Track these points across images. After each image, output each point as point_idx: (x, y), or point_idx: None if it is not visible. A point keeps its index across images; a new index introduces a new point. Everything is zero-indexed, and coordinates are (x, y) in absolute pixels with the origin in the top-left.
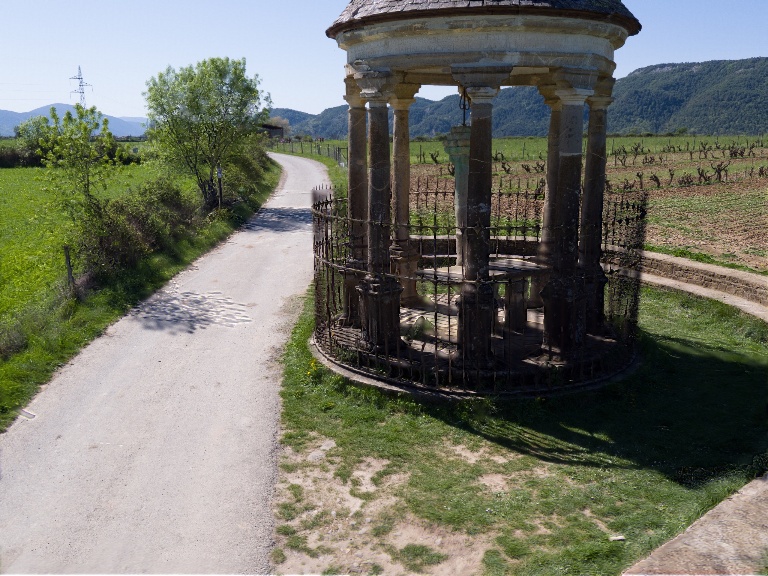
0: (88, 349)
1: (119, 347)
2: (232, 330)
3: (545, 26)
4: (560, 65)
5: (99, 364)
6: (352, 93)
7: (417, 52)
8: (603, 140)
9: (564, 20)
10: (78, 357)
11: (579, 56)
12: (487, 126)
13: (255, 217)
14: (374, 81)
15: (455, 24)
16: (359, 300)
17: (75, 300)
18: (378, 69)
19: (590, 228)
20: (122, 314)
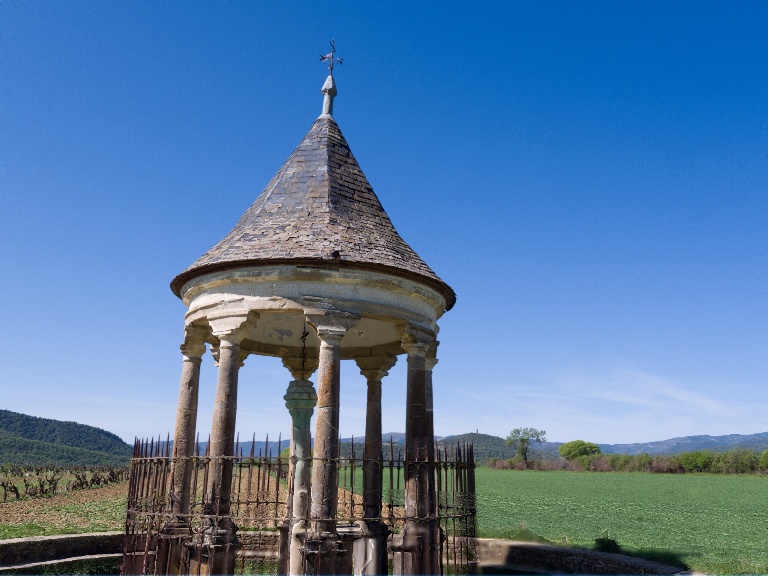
0: None
1: None
2: None
3: (443, 308)
4: None
5: None
6: (243, 328)
7: (387, 304)
8: None
9: None
10: None
11: None
12: None
13: None
14: (342, 320)
15: (418, 290)
16: (306, 568)
17: None
18: (346, 310)
19: None
20: None
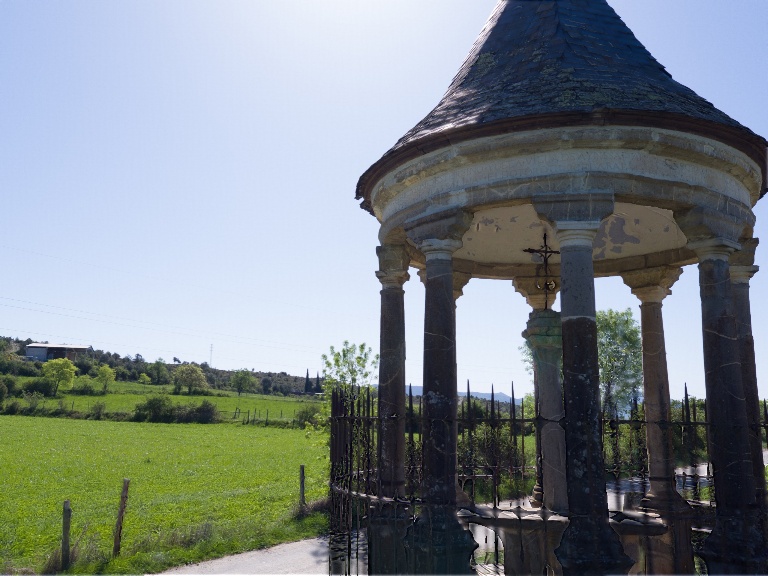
0: (232, 557)
1: (253, 560)
2: (360, 567)
3: (489, 150)
4: (528, 195)
5: (212, 569)
6: None
7: None
8: (721, 307)
9: (514, 136)
10: (213, 561)
11: (559, 178)
12: (437, 288)
13: (622, 480)
14: None
15: (400, 176)
16: None
17: (292, 518)
18: None
19: (718, 458)
20: (311, 536)
